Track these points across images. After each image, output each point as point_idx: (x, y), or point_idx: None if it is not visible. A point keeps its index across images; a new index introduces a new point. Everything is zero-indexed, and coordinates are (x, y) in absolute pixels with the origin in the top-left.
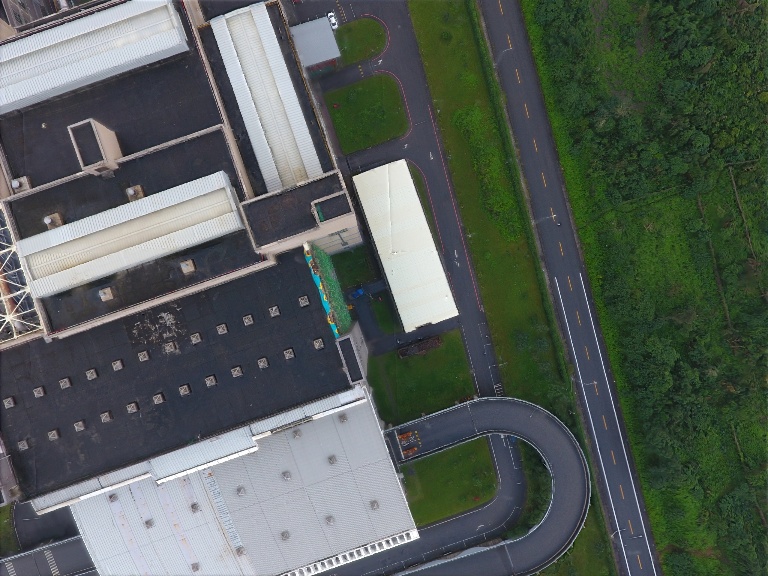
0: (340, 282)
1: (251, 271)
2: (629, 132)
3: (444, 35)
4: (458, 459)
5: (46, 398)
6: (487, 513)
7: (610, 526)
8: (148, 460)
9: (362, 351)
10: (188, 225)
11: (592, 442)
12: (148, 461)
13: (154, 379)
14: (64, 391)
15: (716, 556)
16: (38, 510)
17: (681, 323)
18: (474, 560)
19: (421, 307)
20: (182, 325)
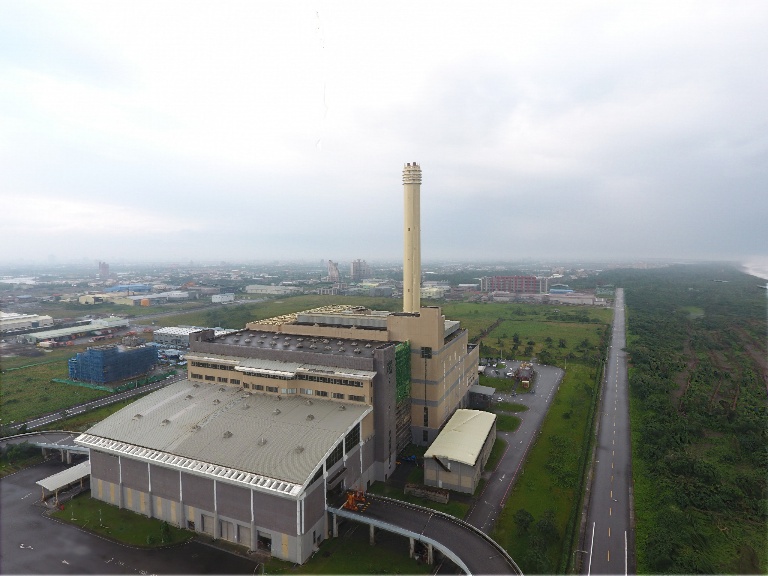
0: (405, 453)
1: (375, 340)
2: (701, 468)
3: (564, 413)
4: None
5: None
6: None
7: None
8: (251, 353)
9: (388, 402)
10: None
11: None
12: None
13: None
14: None
15: None
16: None
17: None
18: None
19: None
20: None
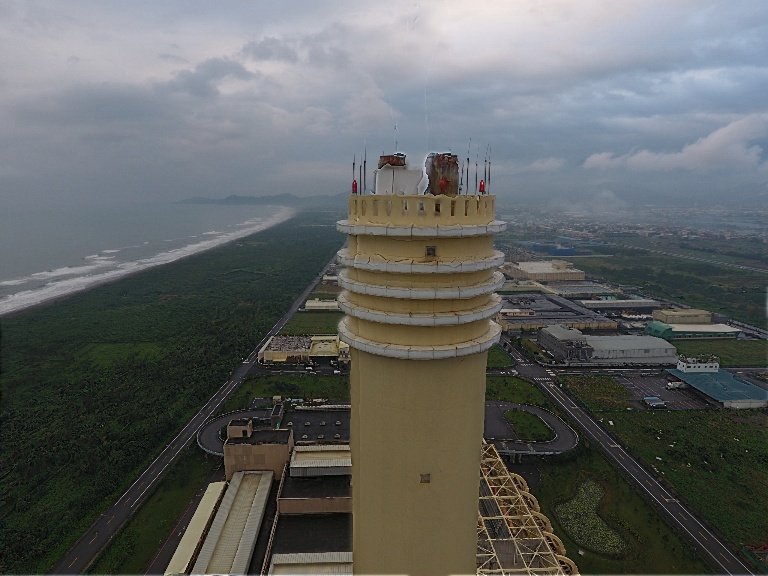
0: None
1: None
2: None
3: None
4: None
5: None
6: None
7: None
8: None
9: None
10: (326, 453)
11: None
12: None
13: None
14: None
15: None
16: None
17: None
18: None
19: None
20: None
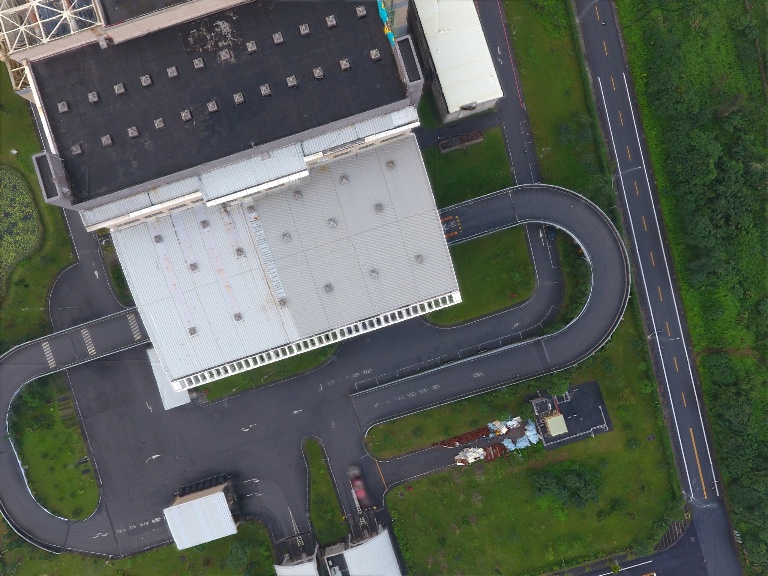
0: None
1: None
2: None
3: None
4: (496, 255)
5: (100, 104)
6: (524, 311)
7: (647, 327)
8: None
9: None
10: None
11: (631, 243)
12: (199, 178)
13: (208, 87)
14: (118, 97)
15: (754, 356)
16: (88, 226)
17: (725, 120)
18: (510, 355)
19: (466, 86)
20: (238, 34)
